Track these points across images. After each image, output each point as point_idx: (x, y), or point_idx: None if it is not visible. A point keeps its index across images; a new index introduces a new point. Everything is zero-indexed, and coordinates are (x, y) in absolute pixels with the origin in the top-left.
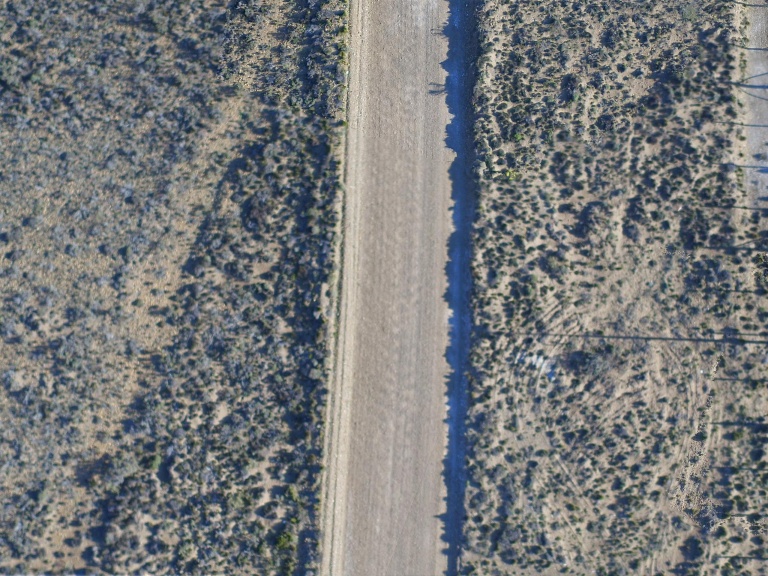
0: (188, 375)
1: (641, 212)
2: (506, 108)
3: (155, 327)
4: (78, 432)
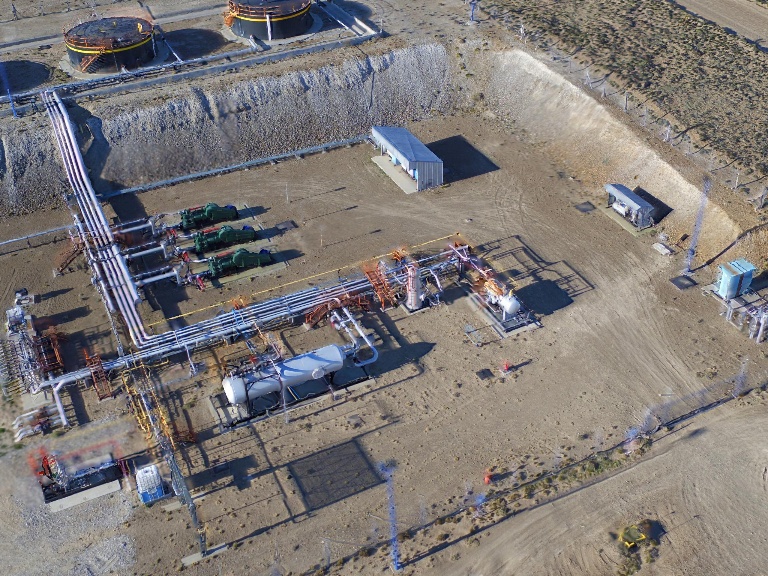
0: None
1: (607, 27)
2: (718, 37)
3: None
4: None
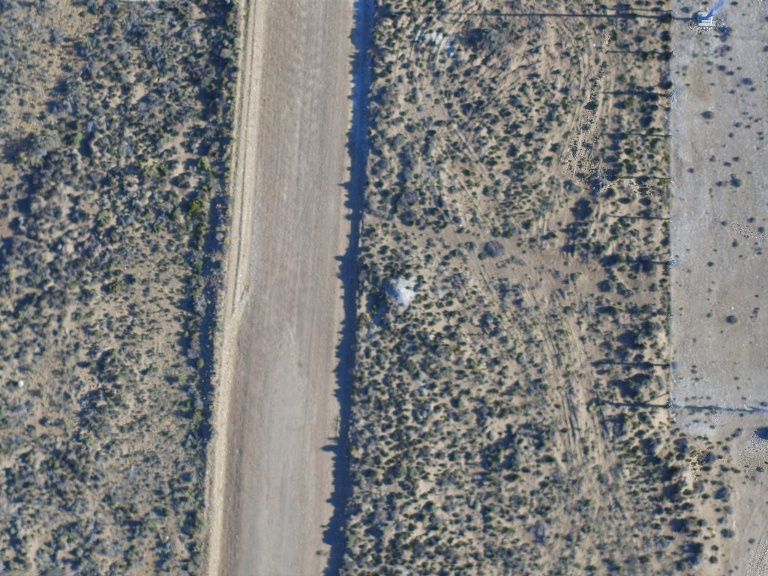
0: (107, 58)
1: None
2: None
3: (77, 17)
4: (5, 113)
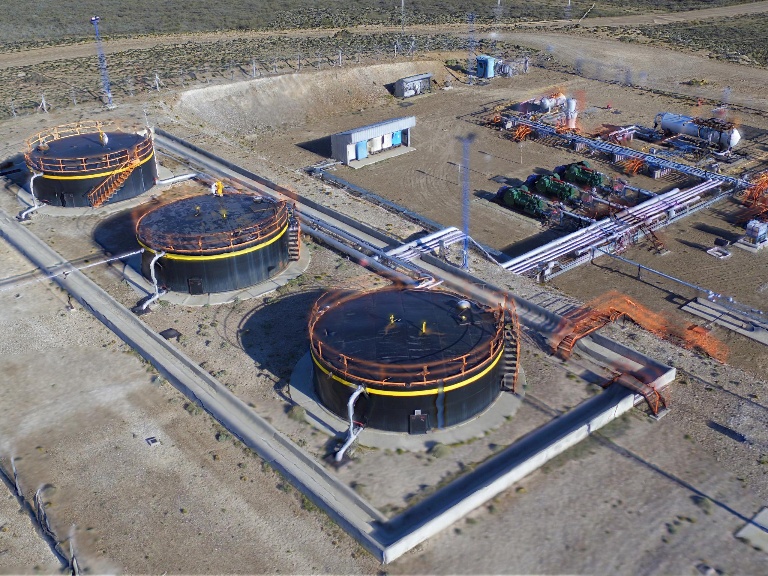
0: None
1: None
2: None
3: None
4: None
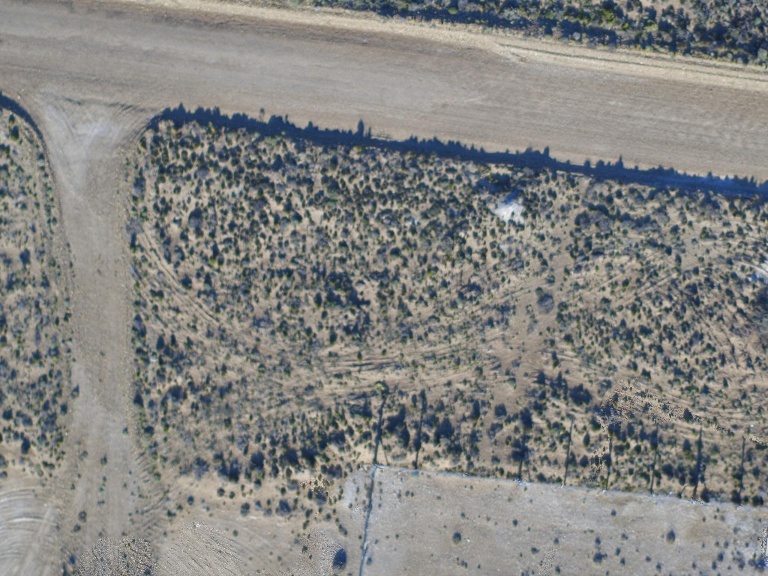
0: None
1: None
2: None
3: None
4: None
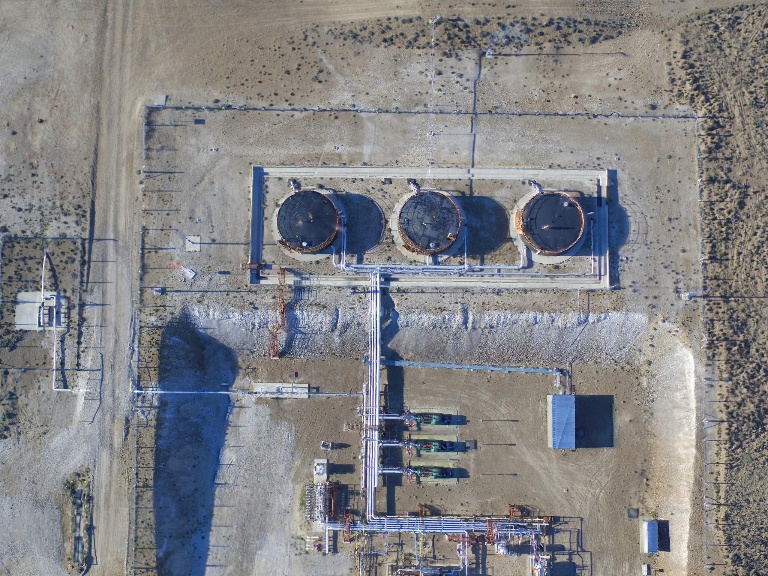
0: None
1: None
2: None
3: None
4: None
